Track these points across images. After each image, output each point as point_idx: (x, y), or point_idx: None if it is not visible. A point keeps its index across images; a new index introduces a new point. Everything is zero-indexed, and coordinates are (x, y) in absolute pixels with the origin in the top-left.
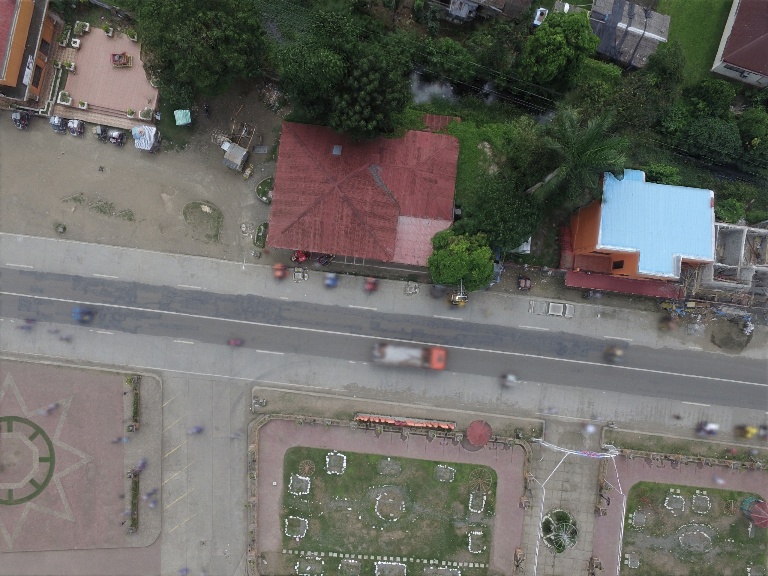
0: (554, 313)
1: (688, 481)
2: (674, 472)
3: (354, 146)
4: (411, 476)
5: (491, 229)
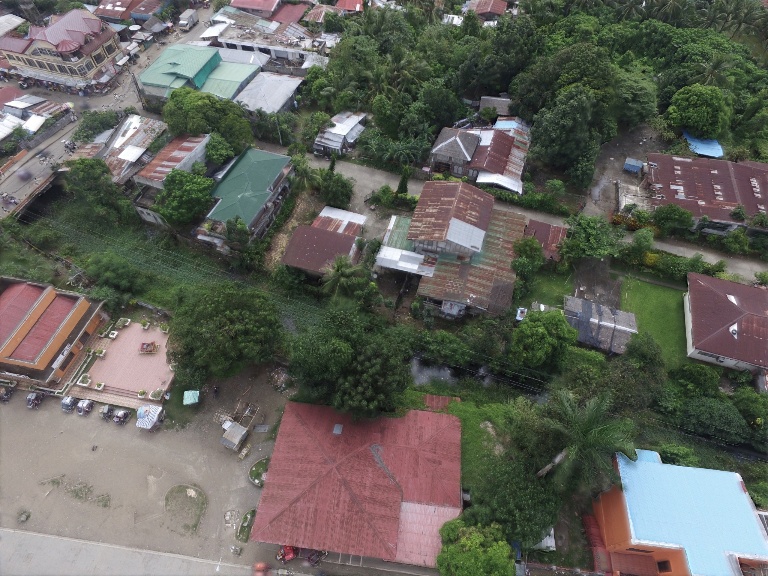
0: None
1: None
2: None
3: (355, 425)
4: None
5: (506, 519)
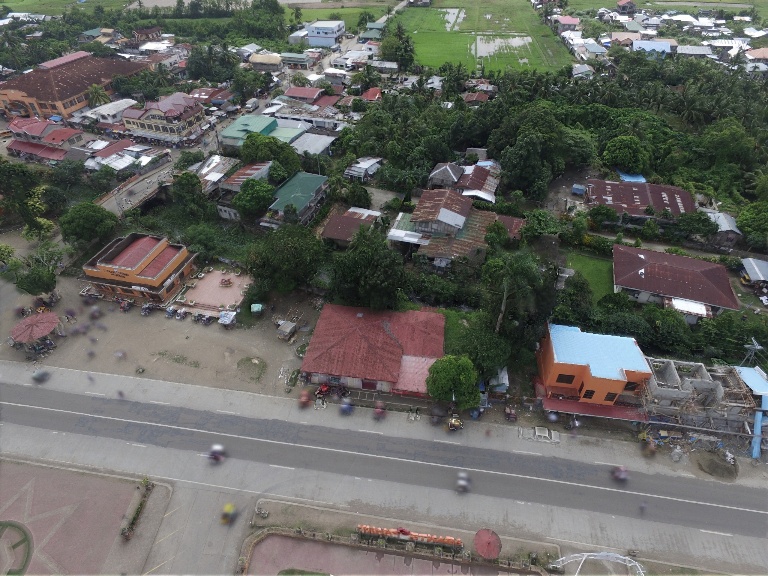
0: (541, 434)
1: None
2: None
3: (371, 314)
4: None
5: (471, 351)
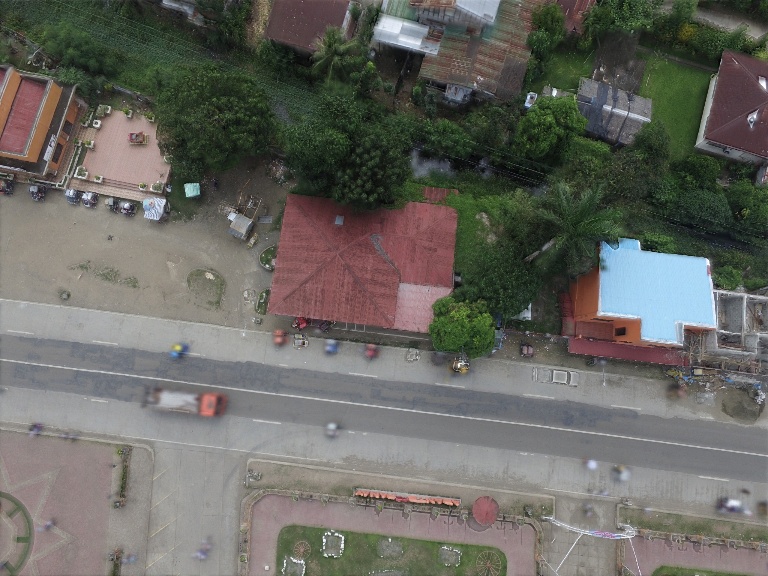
0: (558, 381)
1: (714, 566)
2: (697, 556)
3: (356, 216)
4: (414, 560)
5: (491, 296)
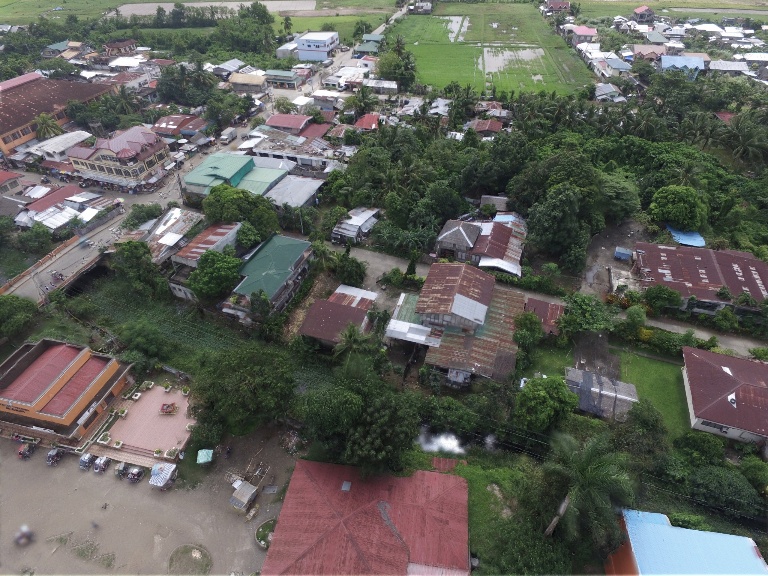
0: None
1: None
2: None
3: (363, 483)
4: None
5: None
